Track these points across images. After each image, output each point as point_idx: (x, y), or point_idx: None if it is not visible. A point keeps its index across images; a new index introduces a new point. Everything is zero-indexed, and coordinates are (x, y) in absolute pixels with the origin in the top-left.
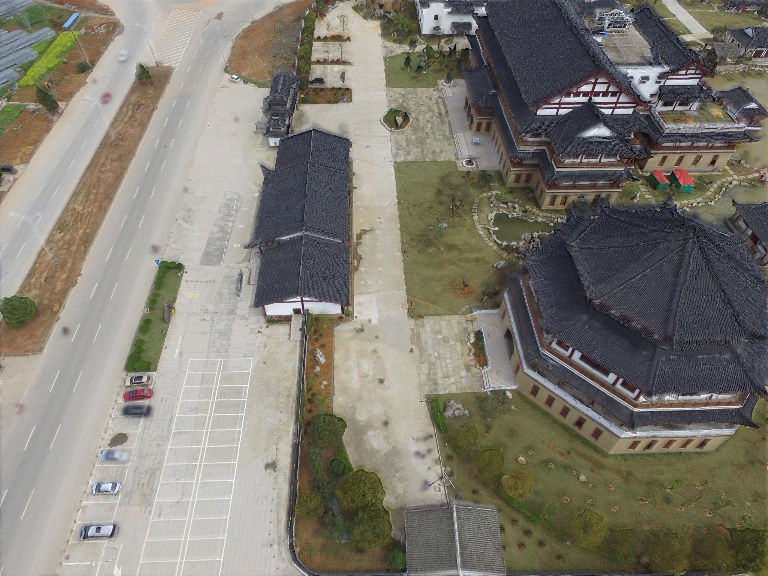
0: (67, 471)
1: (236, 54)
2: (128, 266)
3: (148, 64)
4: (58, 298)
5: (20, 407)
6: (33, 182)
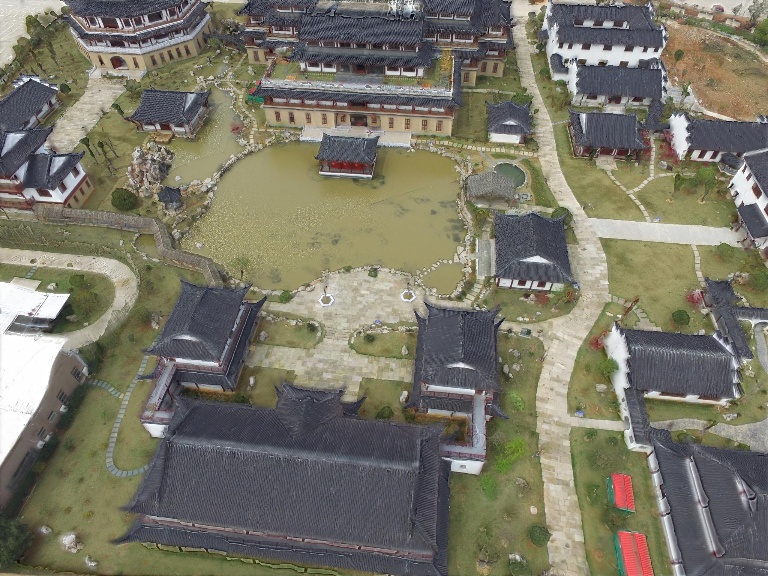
0: None
1: None
2: None
3: None
4: None
5: None
6: None
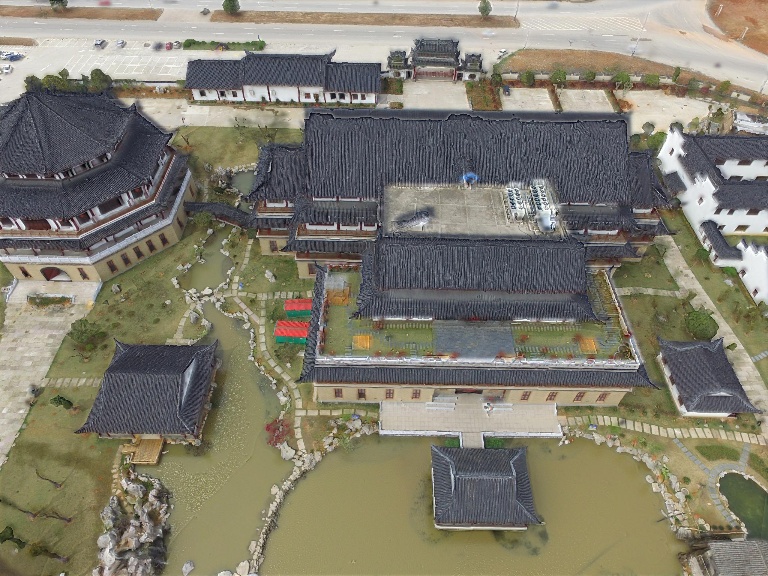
0: (137, 35)
1: (556, 52)
2: (267, 35)
3: (521, 17)
4: (247, 20)
5: (179, 22)
6: (355, 1)
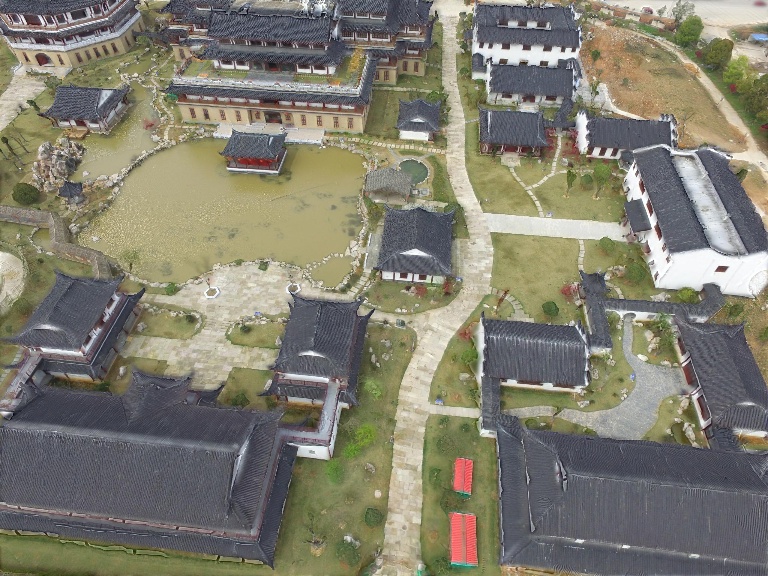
0: None
1: None
2: None
3: None
4: None
5: None
6: None
